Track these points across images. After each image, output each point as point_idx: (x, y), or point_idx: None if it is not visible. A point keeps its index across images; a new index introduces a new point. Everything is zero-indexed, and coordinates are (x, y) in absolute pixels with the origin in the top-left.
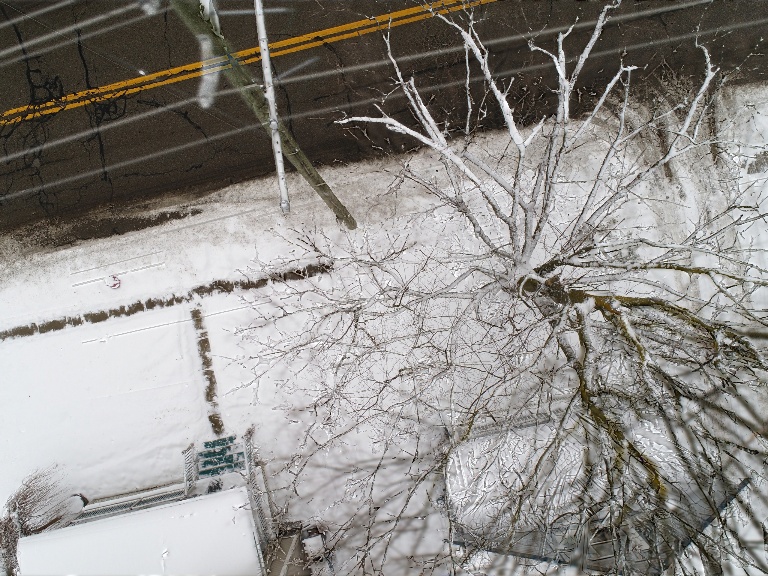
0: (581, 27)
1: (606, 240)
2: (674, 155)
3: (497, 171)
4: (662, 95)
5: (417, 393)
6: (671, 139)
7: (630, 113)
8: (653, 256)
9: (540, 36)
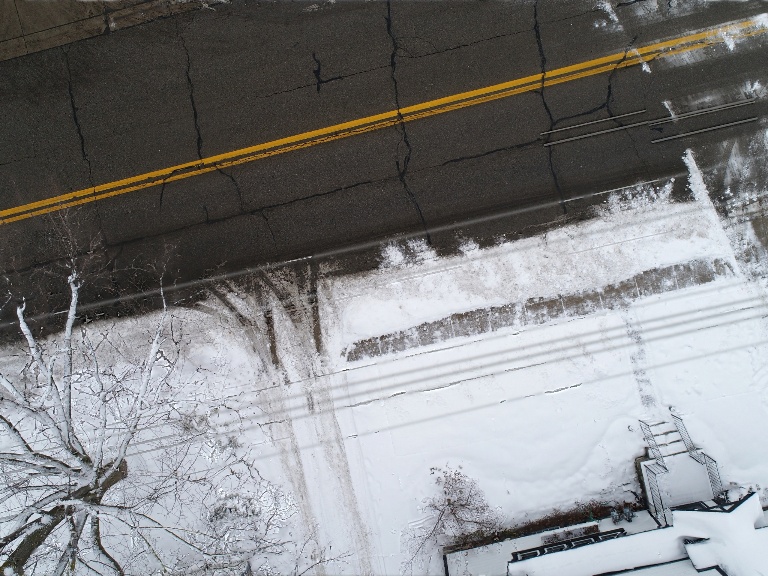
0: (189, 221)
1: (207, 429)
2: (140, 413)
3: (113, 359)
4: (268, 285)
5: (43, 570)
6: (276, 328)
7: (238, 303)
8: (258, 441)
9: (152, 230)
